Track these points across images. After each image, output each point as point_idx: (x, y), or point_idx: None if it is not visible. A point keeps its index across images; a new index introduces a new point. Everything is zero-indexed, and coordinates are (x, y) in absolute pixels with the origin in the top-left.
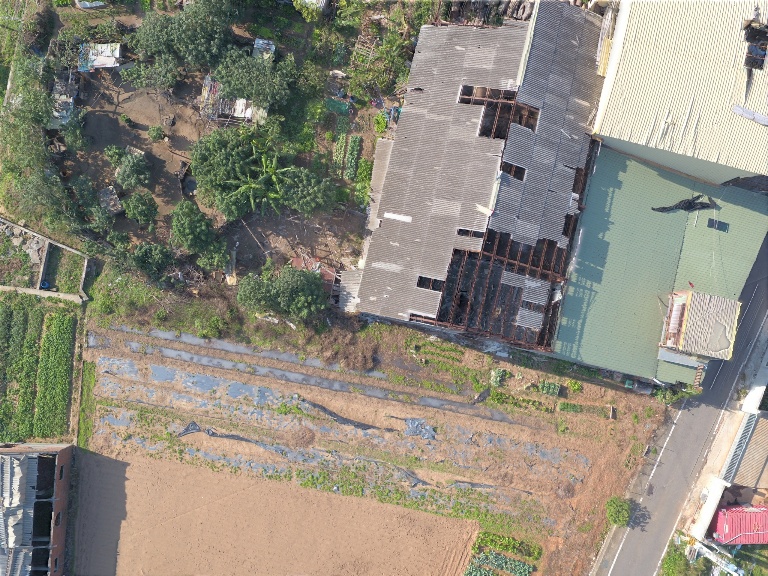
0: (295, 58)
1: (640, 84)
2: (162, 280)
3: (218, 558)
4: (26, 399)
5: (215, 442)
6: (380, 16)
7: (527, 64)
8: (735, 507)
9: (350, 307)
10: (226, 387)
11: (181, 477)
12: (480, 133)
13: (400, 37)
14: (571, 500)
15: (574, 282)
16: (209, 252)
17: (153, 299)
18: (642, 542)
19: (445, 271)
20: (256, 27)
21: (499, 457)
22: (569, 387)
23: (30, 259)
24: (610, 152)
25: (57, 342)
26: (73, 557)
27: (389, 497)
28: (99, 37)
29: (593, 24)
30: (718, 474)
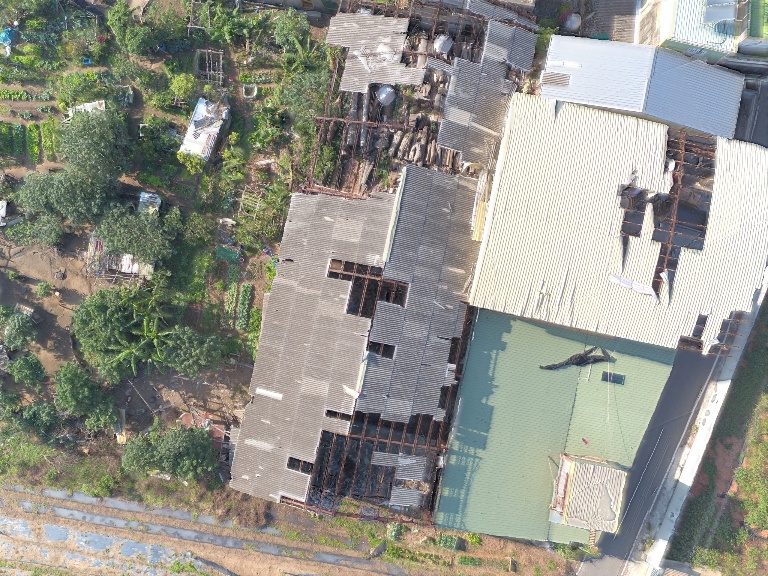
0: (185, 206)
1: (512, 256)
2: (50, 442)
3: None
4: None
5: None
6: (270, 160)
7: (394, 239)
8: None
9: None
10: (119, 546)
11: None
12: (348, 310)
13: (286, 187)
14: None
15: (456, 450)
16: (97, 413)
17: (44, 459)
18: None
19: (314, 453)
20: (145, 176)
21: None
22: (467, 539)
23: None
24: (492, 314)
25: None
26: None
27: None
28: None
29: (467, 188)
30: None
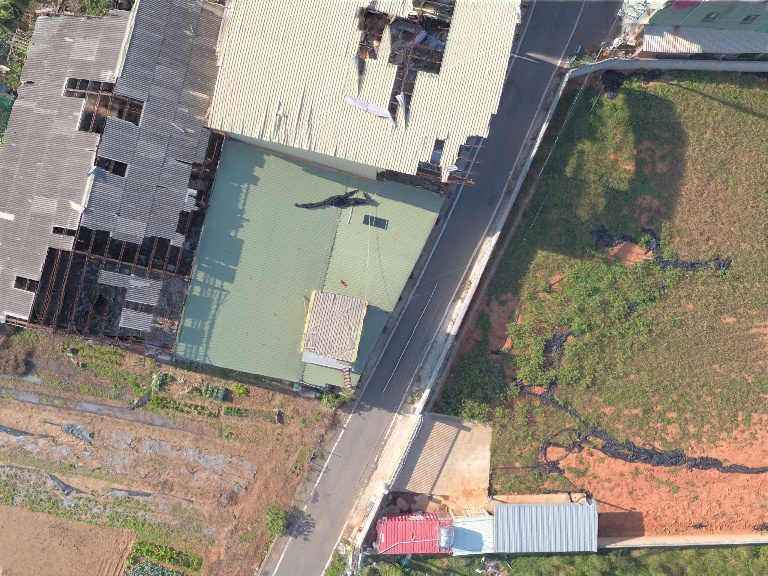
0: None
1: (247, 75)
2: None
3: None
4: None
5: None
6: (49, 9)
7: (127, 55)
8: (403, 515)
9: None
10: None
11: None
12: (80, 127)
13: None
14: (234, 508)
15: (201, 282)
16: None
17: None
18: (305, 551)
19: (39, 271)
20: None
21: (159, 464)
22: (234, 391)
23: None
24: (244, 146)
25: None
26: None
27: (41, 506)
28: None
29: (212, 13)
30: (389, 480)
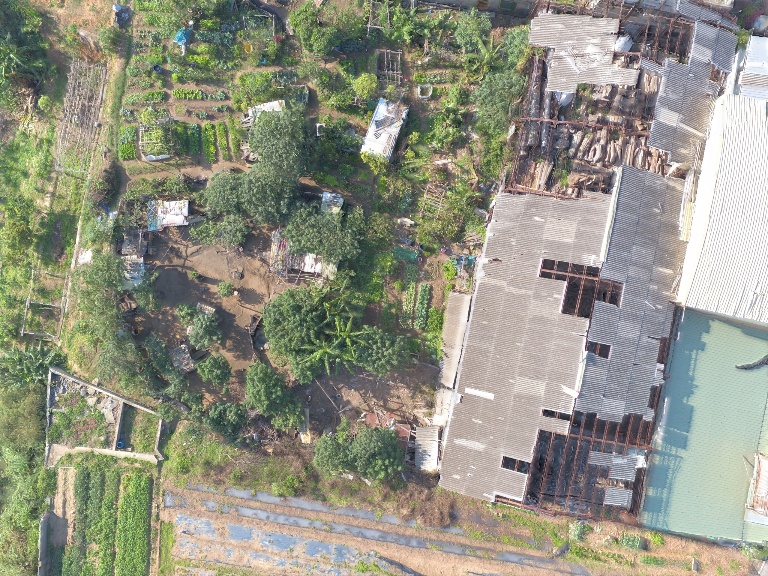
0: (362, 206)
1: (727, 256)
2: (237, 442)
3: None
4: (105, 561)
5: None
6: (447, 160)
7: (610, 239)
8: None
9: (426, 466)
10: (302, 545)
11: None
12: (563, 310)
13: (470, 187)
14: None
15: (659, 450)
16: (283, 412)
17: (228, 458)
18: None
19: (530, 453)
20: (322, 175)
21: None
22: (649, 538)
23: (105, 419)
24: (693, 313)
25: (134, 504)
26: None
27: None
28: (167, 195)
29: (675, 189)
30: None
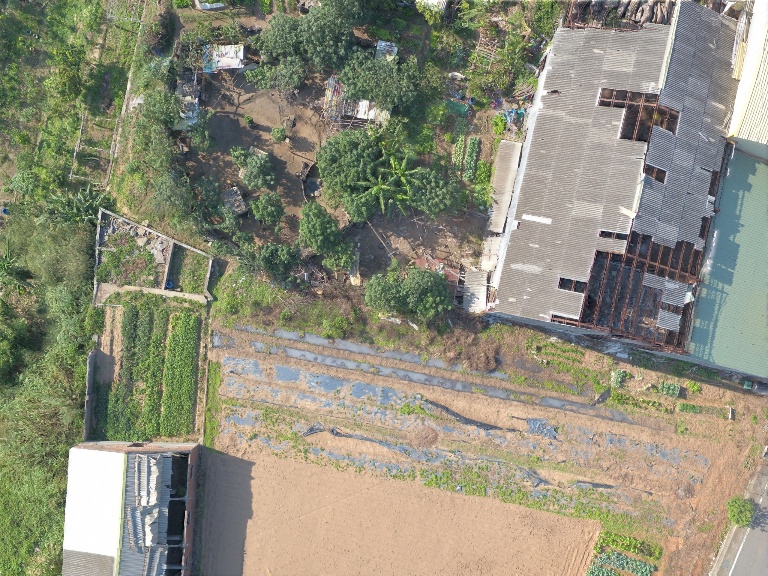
0: None
1: None
2: (289, 281)
3: (343, 557)
4: (153, 398)
5: (339, 442)
6: (498, 18)
7: (669, 67)
8: None
9: (475, 308)
10: (350, 387)
11: (306, 476)
12: (621, 136)
13: (522, 39)
14: (691, 500)
15: (706, 284)
16: (335, 253)
17: (277, 299)
18: (762, 542)
19: (588, 273)
20: (375, 29)
21: (619, 457)
22: (688, 388)
23: (155, 259)
24: (741, 155)
25: (183, 342)
26: (200, 556)
27: (512, 497)
28: (223, 38)
29: (729, 27)
30: None
